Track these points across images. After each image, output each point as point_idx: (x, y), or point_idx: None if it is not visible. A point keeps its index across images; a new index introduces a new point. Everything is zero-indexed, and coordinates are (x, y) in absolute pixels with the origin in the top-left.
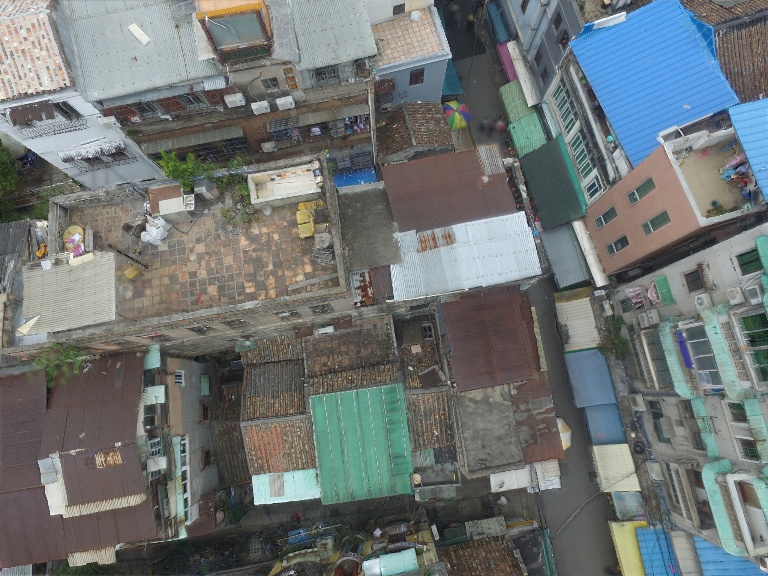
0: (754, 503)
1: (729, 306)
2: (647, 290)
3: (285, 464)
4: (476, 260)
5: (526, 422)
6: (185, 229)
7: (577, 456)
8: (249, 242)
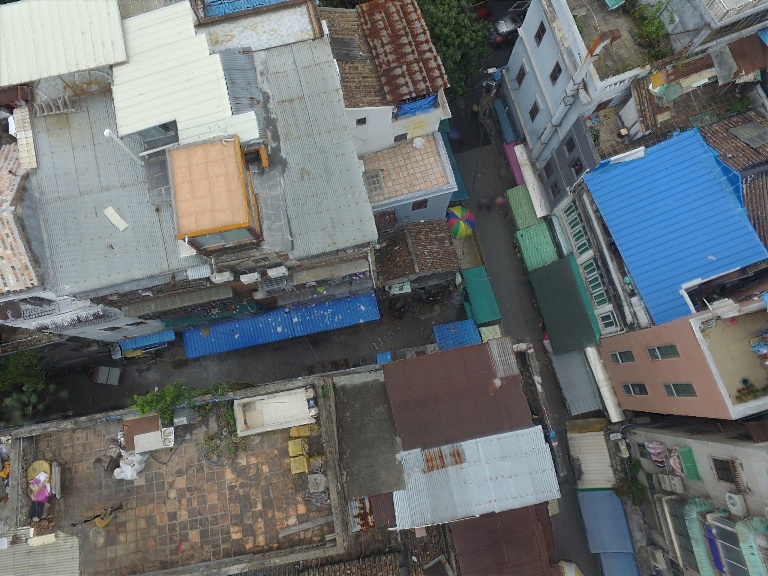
0: None
1: (767, 524)
2: (669, 451)
3: None
4: (488, 482)
5: None
6: (164, 458)
7: None
8: (235, 475)
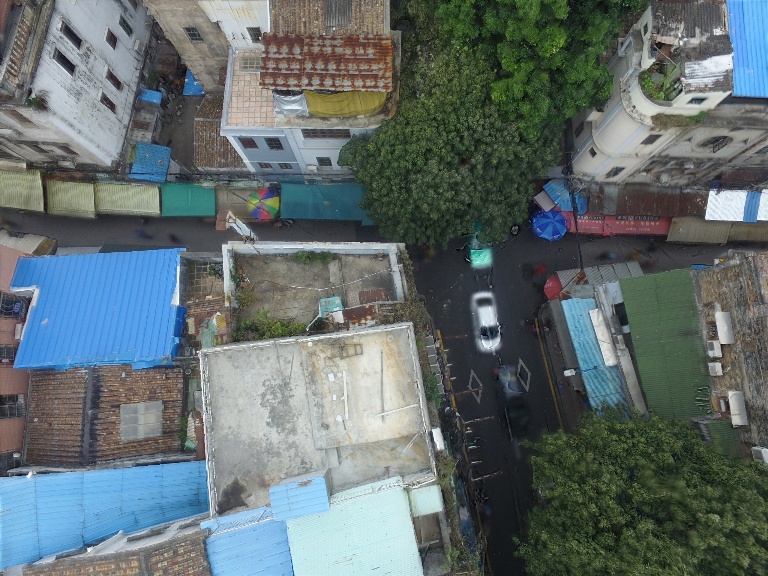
0: None
1: None
2: None
3: None
4: None
5: None
6: None
7: None
8: None
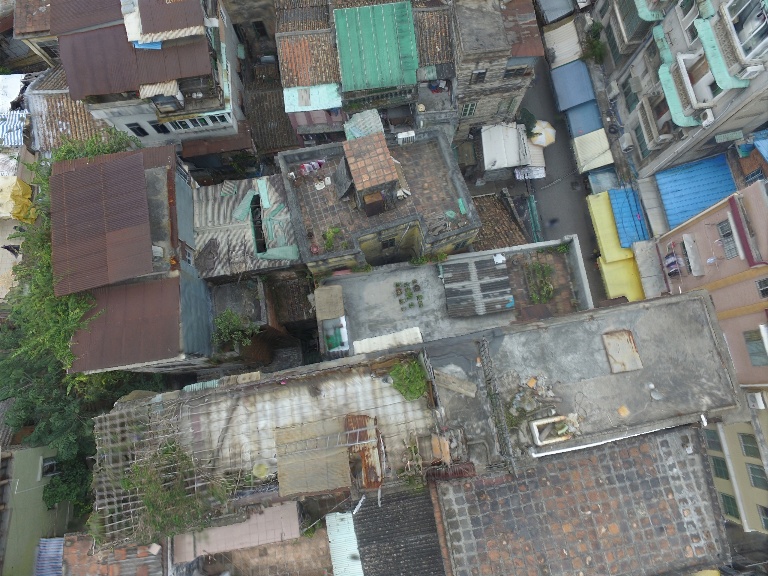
0: (699, 78)
1: None
2: None
3: (311, 77)
4: None
5: (513, 28)
6: None
7: (561, 170)
8: None
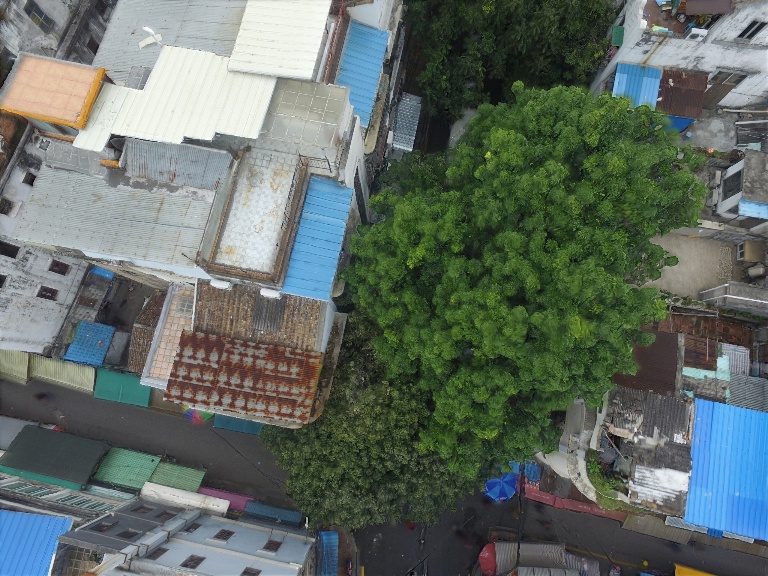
0: None
1: None
2: None
3: None
4: None
5: None
6: None
7: None
8: None
